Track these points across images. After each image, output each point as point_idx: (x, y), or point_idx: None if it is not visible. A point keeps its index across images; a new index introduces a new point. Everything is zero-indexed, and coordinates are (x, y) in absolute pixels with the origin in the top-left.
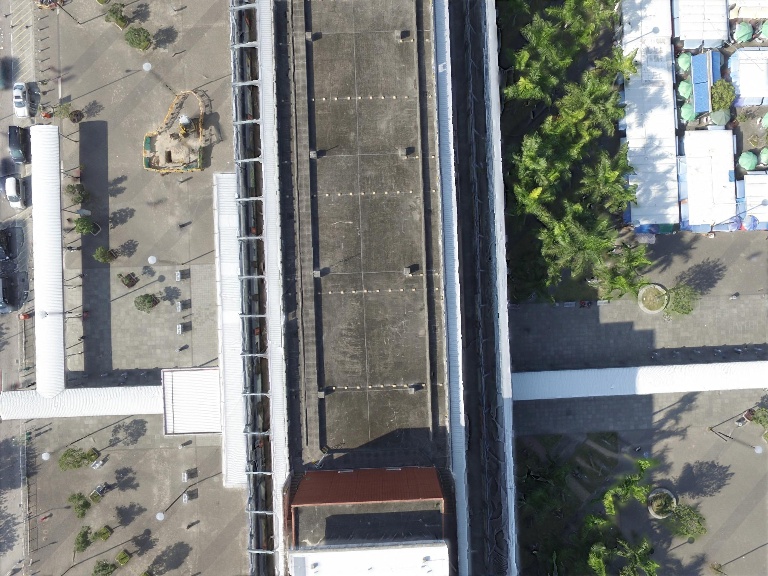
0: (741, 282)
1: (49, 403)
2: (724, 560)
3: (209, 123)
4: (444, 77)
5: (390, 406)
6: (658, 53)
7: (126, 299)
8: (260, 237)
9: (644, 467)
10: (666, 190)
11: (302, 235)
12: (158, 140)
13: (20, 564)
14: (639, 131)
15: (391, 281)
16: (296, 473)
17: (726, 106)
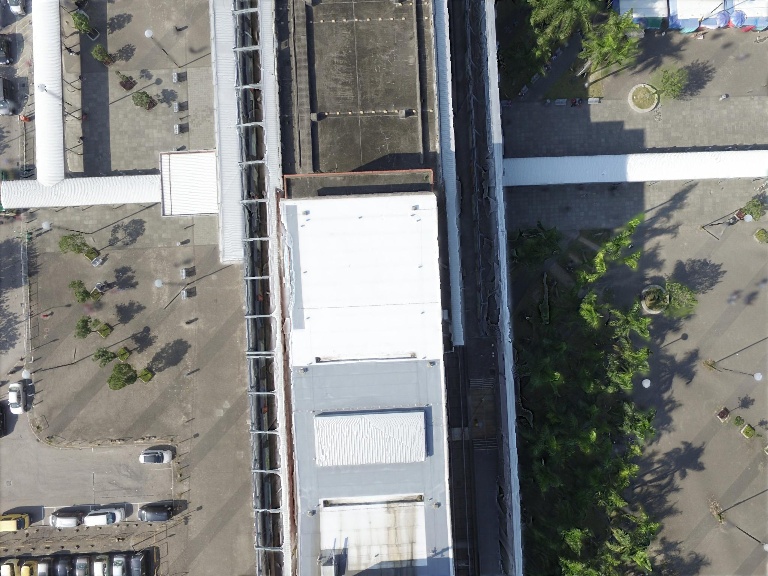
0: (730, 84)
1: (49, 191)
2: (718, 357)
3: None
4: None
5: (381, 131)
6: None
7: (124, 102)
8: None
9: (634, 225)
10: None
11: None
12: None
13: (22, 362)
14: None
15: (381, 10)
16: None
17: None
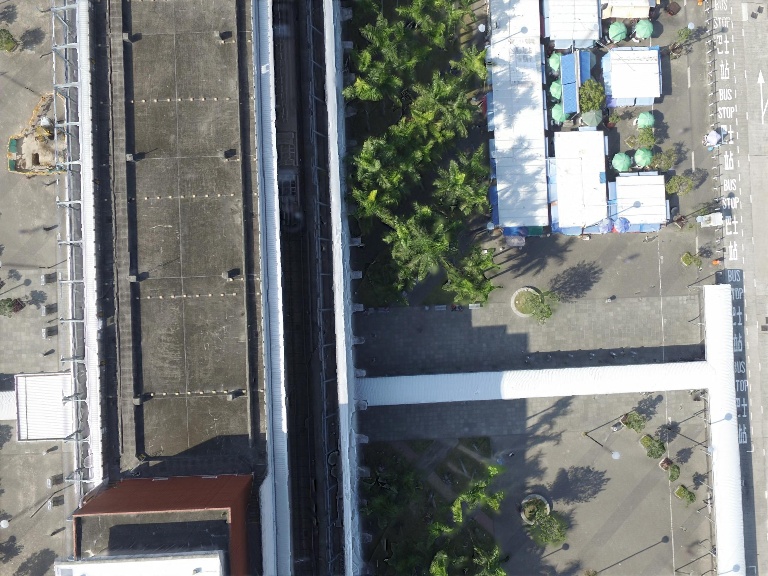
0: (618, 285)
1: None
2: (600, 567)
3: None
4: (267, 78)
5: (210, 413)
6: (527, 53)
7: None
8: (79, 241)
9: (492, 474)
10: (535, 192)
11: (119, 239)
12: (25, 142)
13: None
14: (507, 132)
15: (211, 286)
16: (111, 481)
17: (596, 107)
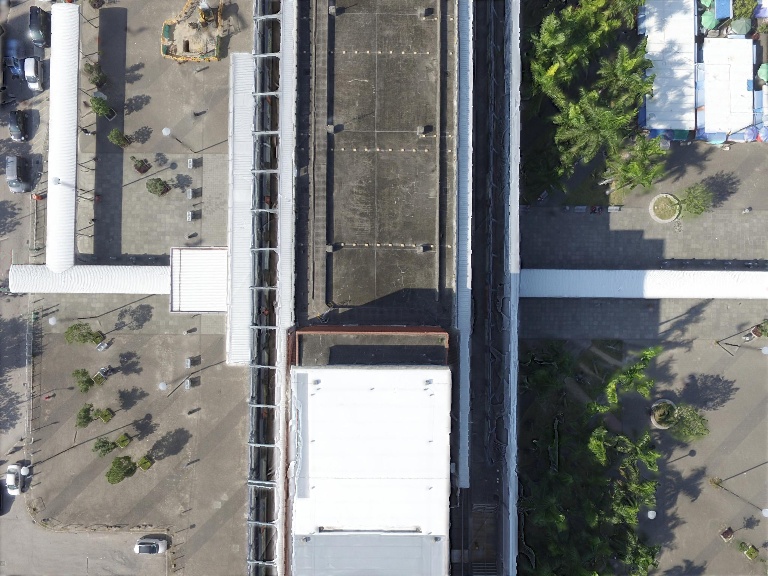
0: (754, 197)
1: (58, 278)
2: (725, 475)
3: (228, 14)
4: None
5: (398, 265)
6: None
7: (138, 185)
8: (275, 92)
9: (649, 357)
10: (683, 96)
11: (317, 90)
12: (176, 29)
13: (22, 442)
14: (658, 35)
15: (404, 141)
16: (301, 326)
17: (747, 14)
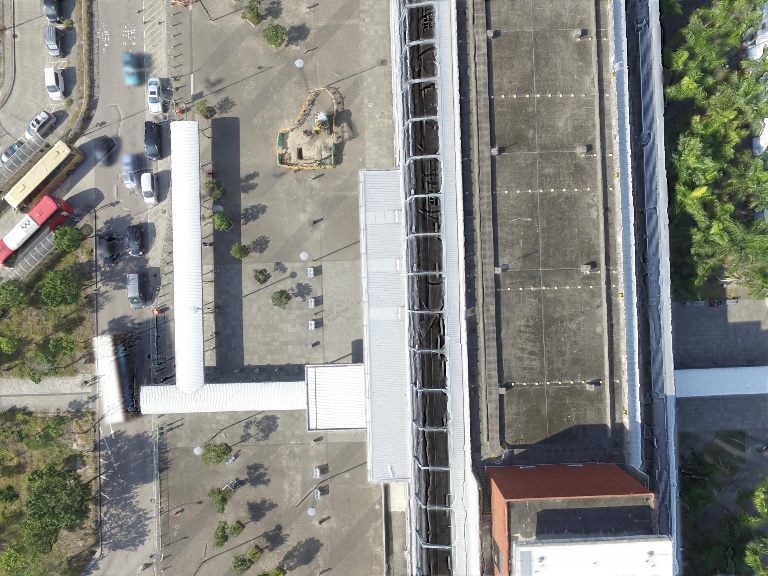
0: None
1: (189, 398)
2: None
3: (341, 120)
4: (621, 75)
5: (568, 402)
6: None
7: (258, 295)
8: (438, 233)
9: None
10: None
11: (483, 232)
12: (290, 137)
13: (151, 559)
14: None
15: (569, 278)
16: (477, 468)
17: None
